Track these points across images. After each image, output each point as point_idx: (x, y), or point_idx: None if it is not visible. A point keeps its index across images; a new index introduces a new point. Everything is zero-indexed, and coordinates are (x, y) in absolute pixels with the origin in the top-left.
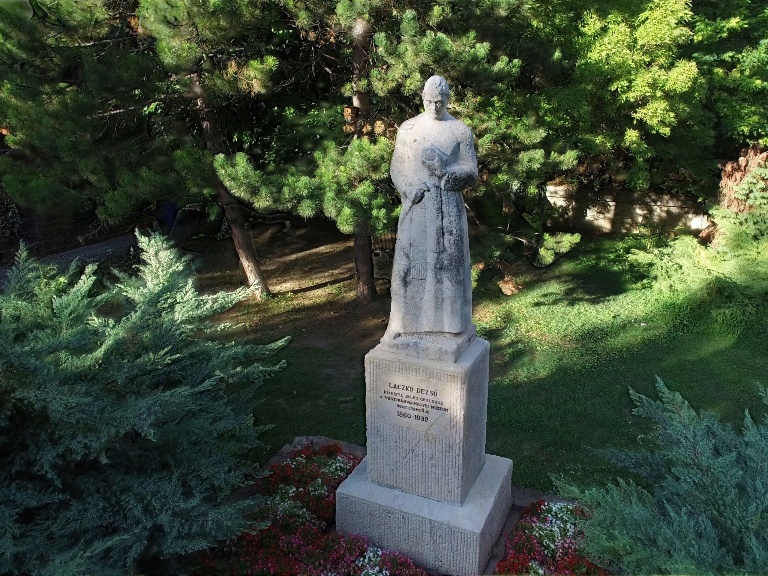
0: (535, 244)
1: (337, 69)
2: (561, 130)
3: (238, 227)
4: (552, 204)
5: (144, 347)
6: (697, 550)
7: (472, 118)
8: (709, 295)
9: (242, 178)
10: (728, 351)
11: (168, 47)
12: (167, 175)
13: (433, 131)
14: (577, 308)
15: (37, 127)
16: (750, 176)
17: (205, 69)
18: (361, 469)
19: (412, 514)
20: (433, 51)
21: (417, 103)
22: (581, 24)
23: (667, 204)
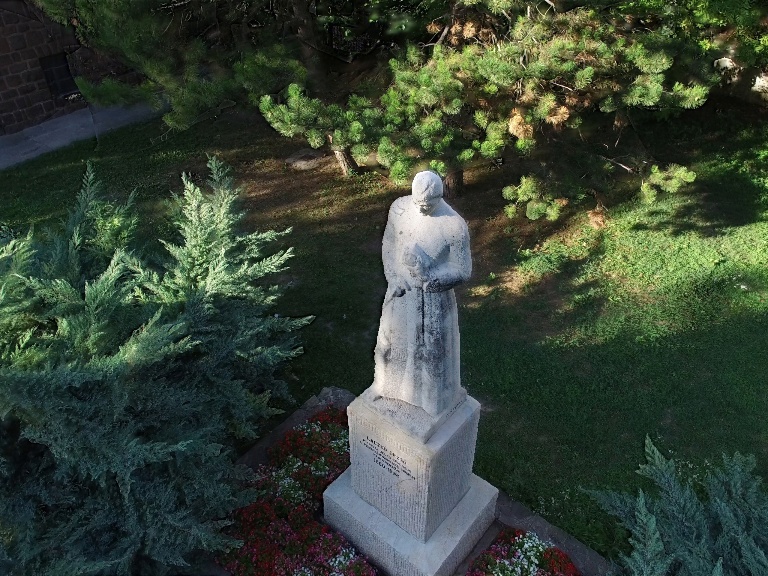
0: (641, 173)
1: None
2: (713, 27)
3: None
4: (715, 64)
5: (181, 309)
6: None
7: (581, 33)
8: None
9: (289, 122)
10: None
11: None
12: None
13: (421, 228)
14: (680, 241)
15: (101, 26)
16: None
17: None
18: None
19: (380, 538)
20: None
21: None
22: None
23: None
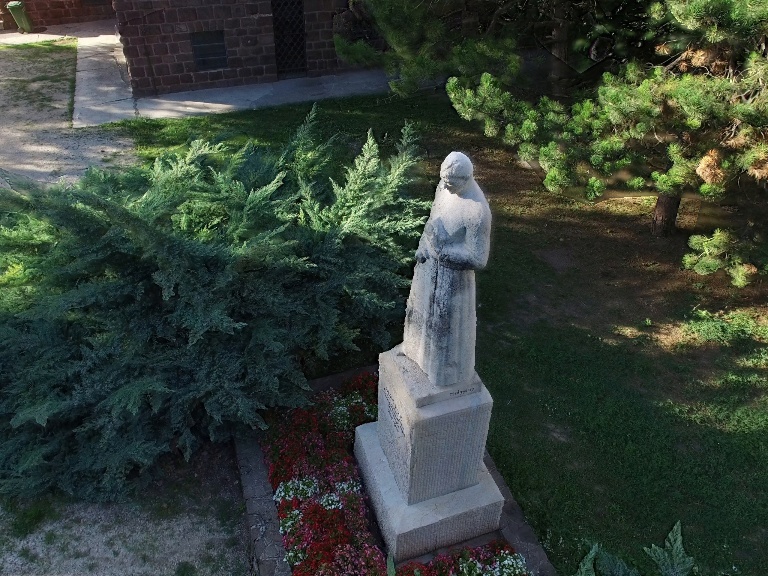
0: None
1: None
2: None
3: None
4: None
5: (323, 238)
6: None
7: None
8: None
9: (467, 106)
10: None
11: None
12: None
13: (447, 204)
14: None
15: None
16: None
17: None
18: None
19: (377, 483)
20: (714, 14)
21: (767, 36)
22: None
23: None
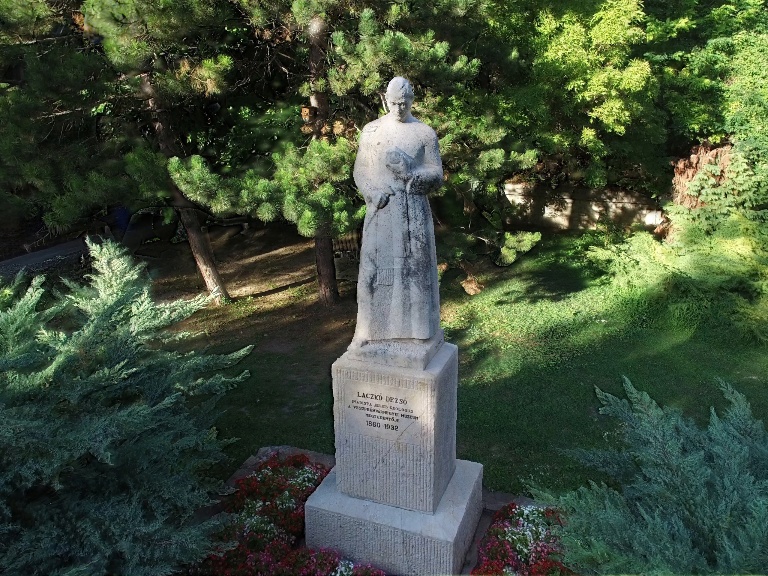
0: (497, 243)
1: (293, 68)
2: (519, 129)
3: (194, 231)
4: (511, 202)
5: (98, 361)
6: (672, 553)
7: (432, 118)
8: (666, 290)
9: (198, 181)
10: (686, 345)
11: (116, 45)
12: (118, 179)
13: (397, 133)
14: (539, 306)
15: None
16: (701, 173)
17: (156, 68)
18: (330, 480)
19: (384, 525)
20: (392, 50)
21: (376, 103)
22: (537, 23)
23: (622, 201)
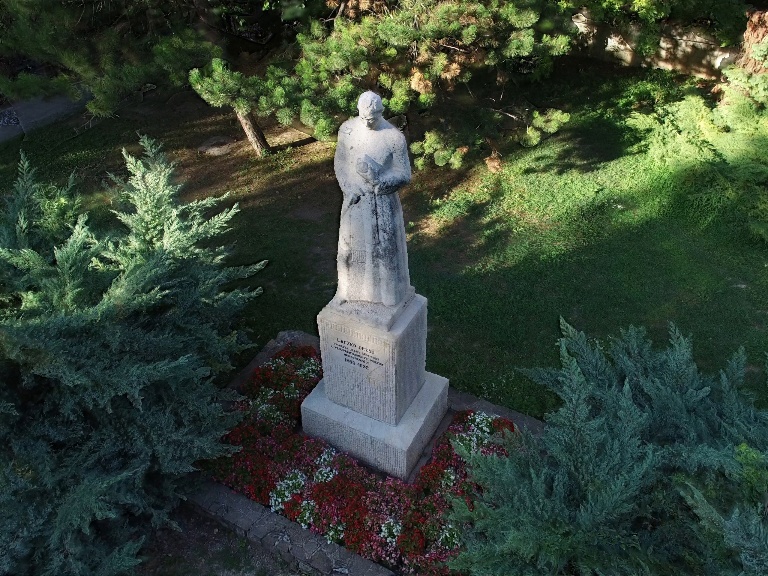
0: (525, 120)
1: None
2: None
3: None
4: None
5: None
6: (542, 507)
7: None
8: (694, 174)
9: (218, 92)
10: (693, 241)
11: None
12: None
13: (368, 141)
14: (565, 178)
15: (15, 21)
16: None
17: None
18: (323, 385)
19: (358, 430)
20: None
21: None
22: None
23: (693, 39)
